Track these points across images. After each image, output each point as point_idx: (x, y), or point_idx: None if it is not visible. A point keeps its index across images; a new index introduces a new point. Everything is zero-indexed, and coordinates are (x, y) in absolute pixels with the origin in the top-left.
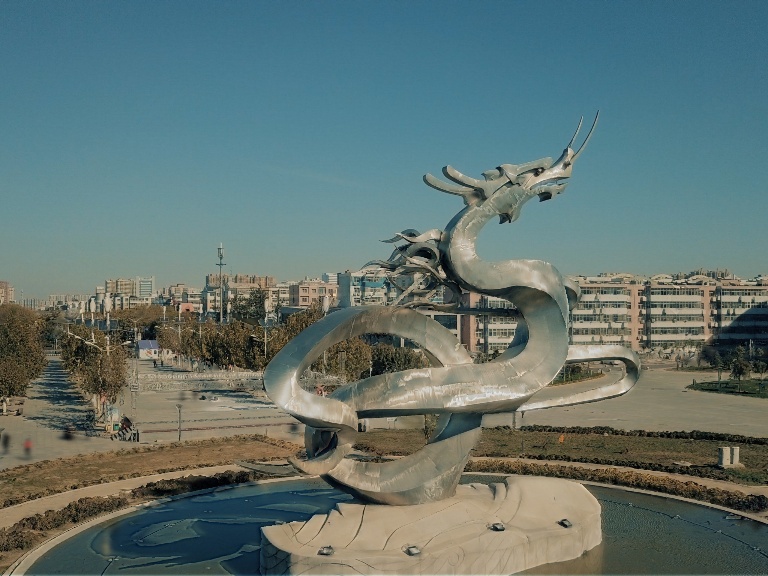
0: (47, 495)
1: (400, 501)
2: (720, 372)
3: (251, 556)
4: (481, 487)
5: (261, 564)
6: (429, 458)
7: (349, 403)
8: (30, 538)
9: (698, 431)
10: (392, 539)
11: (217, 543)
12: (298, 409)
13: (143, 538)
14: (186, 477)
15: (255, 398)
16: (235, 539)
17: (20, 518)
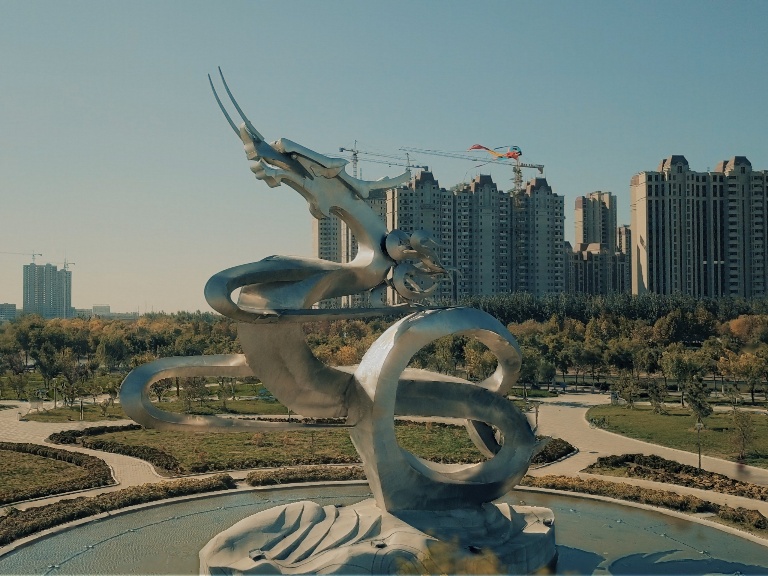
0: None
1: None
2: None
3: (589, 568)
4: (349, 510)
5: None
6: None
7: None
8: None
9: None
10: None
11: None
12: None
13: None
14: None
15: None
16: None
17: None
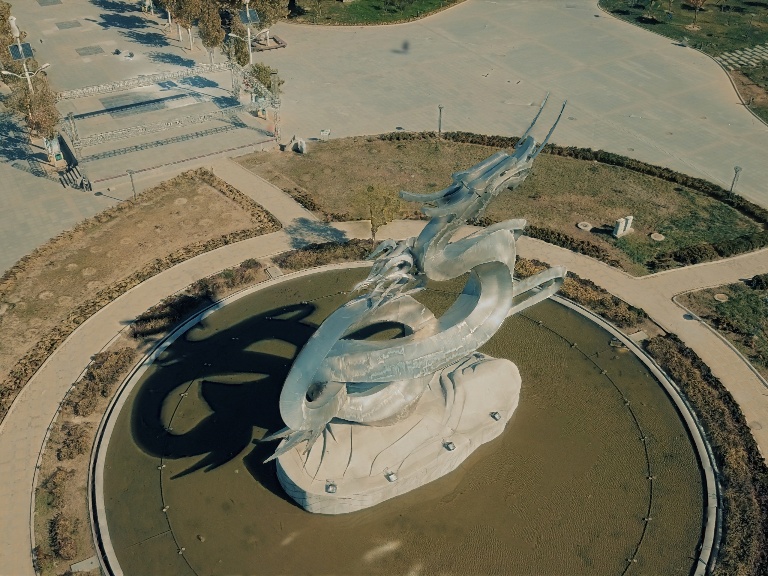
0: (60, 344)
1: (378, 425)
2: (634, 0)
3: (263, 445)
4: (435, 386)
5: (279, 476)
6: (399, 391)
7: (339, 374)
8: (85, 441)
9: (602, 152)
10: (376, 464)
11: (229, 418)
12: (309, 426)
13: (171, 422)
14: (172, 303)
15: (170, 45)
16: (241, 408)
17: (57, 394)
